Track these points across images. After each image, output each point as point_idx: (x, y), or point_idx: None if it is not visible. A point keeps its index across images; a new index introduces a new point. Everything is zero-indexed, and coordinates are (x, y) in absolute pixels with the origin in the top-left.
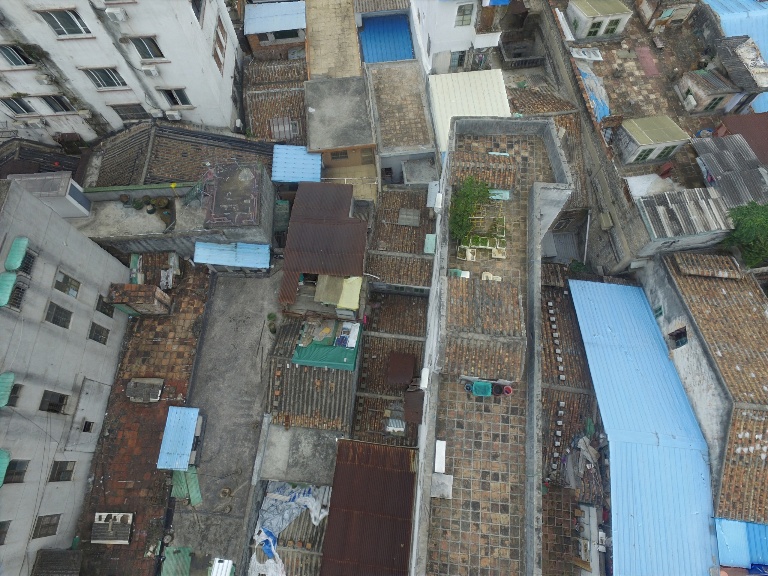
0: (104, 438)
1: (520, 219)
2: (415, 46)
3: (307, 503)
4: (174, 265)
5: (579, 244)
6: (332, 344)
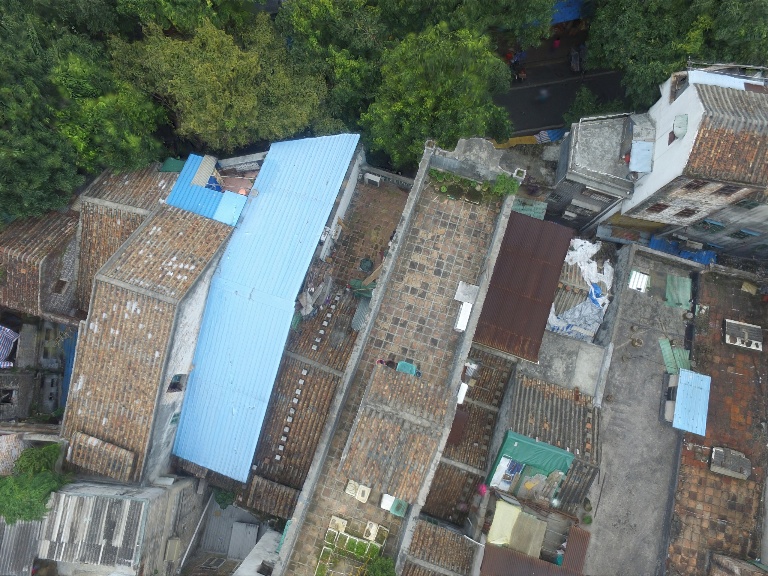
0: (766, 420)
1: (296, 568)
2: None
3: (557, 321)
4: None
5: (203, 532)
6: (527, 466)
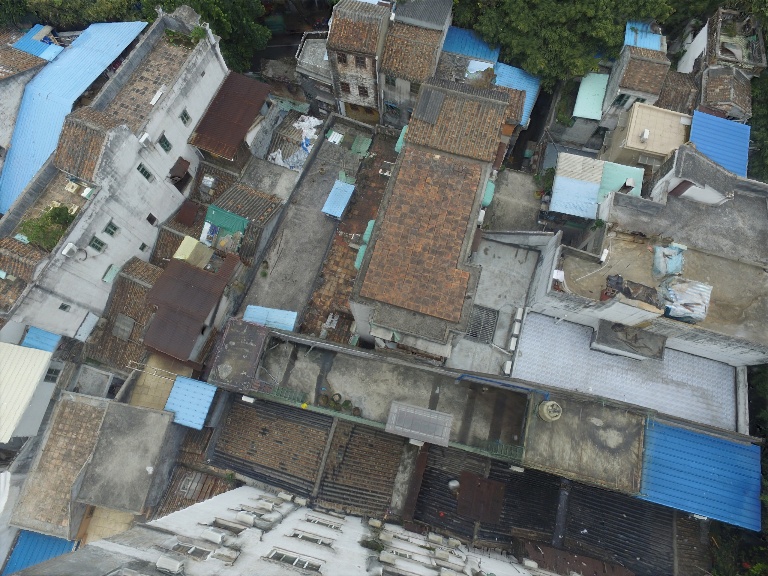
0: None
1: None
2: (0, 551)
3: (283, 164)
4: (323, 330)
5: None
6: (220, 229)
